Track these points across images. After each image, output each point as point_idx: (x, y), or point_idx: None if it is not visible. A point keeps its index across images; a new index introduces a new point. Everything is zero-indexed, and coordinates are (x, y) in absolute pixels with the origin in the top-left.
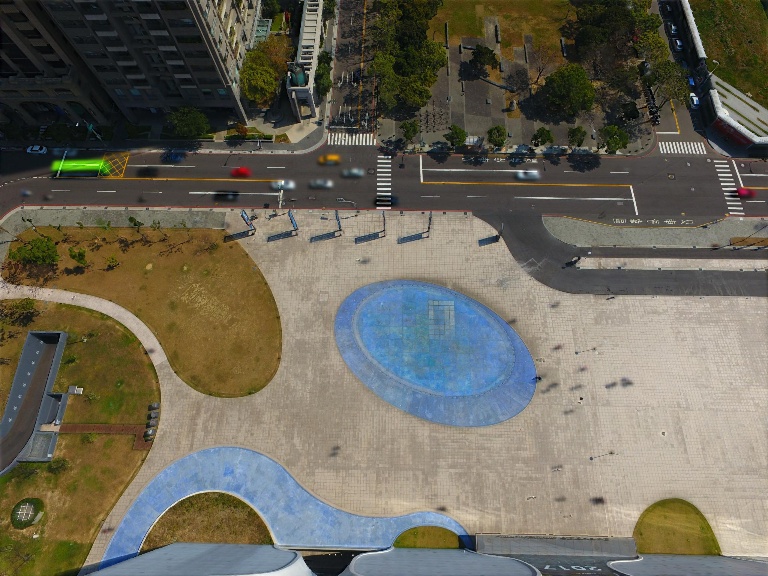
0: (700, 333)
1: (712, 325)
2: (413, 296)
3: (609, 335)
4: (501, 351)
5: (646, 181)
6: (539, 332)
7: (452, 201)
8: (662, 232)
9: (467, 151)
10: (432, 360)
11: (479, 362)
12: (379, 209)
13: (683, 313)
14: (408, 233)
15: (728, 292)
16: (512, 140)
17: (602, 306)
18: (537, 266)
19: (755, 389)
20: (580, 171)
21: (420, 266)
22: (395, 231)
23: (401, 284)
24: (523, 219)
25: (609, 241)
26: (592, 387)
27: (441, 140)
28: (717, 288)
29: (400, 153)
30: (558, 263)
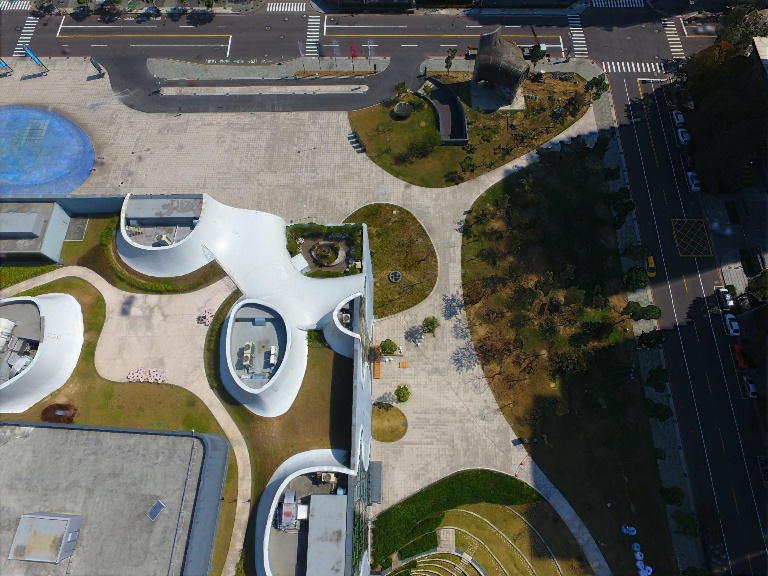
0: (238, 137)
1: (251, 132)
2: (18, 117)
3: (165, 140)
4: (74, 153)
5: (245, 32)
6: (109, 139)
7: (77, 49)
8: (242, 68)
9: (104, 12)
10: (16, 161)
11: (53, 161)
12: (14, 56)
13: (232, 124)
14: (32, 72)
15: (275, 109)
16: (144, 3)
17: (169, 121)
18: (129, 94)
19: (263, 174)
20: (193, 26)
21: (32, 95)
22: (21, 71)
23: (12, 108)
24: (131, 61)
25: (195, 75)
26: (134, 175)
27: (85, 5)
28: (268, 106)
29: (48, 15)
30: (147, 92)
